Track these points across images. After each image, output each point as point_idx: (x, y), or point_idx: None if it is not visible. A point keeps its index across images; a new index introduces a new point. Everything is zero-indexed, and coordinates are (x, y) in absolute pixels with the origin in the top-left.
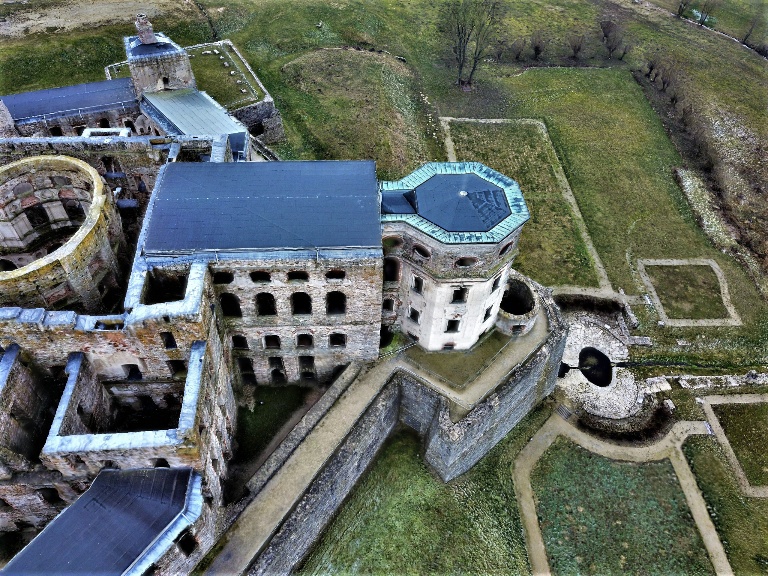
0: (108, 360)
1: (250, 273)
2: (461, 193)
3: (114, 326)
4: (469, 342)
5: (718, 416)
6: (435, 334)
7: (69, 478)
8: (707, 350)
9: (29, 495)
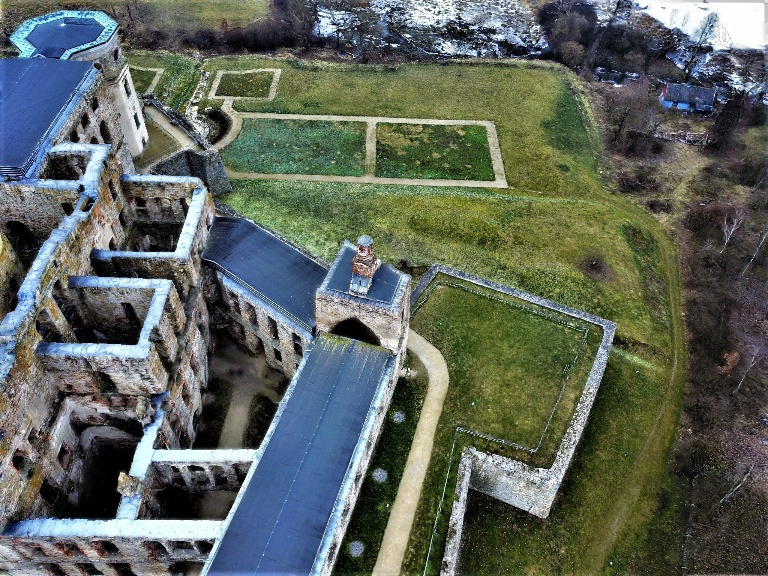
0: (103, 246)
1: (70, 139)
2: (62, 25)
3: (88, 206)
4: (146, 130)
5: (223, 95)
6: (136, 135)
7: (198, 284)
8: (175, 88)
9: (196, 330)
